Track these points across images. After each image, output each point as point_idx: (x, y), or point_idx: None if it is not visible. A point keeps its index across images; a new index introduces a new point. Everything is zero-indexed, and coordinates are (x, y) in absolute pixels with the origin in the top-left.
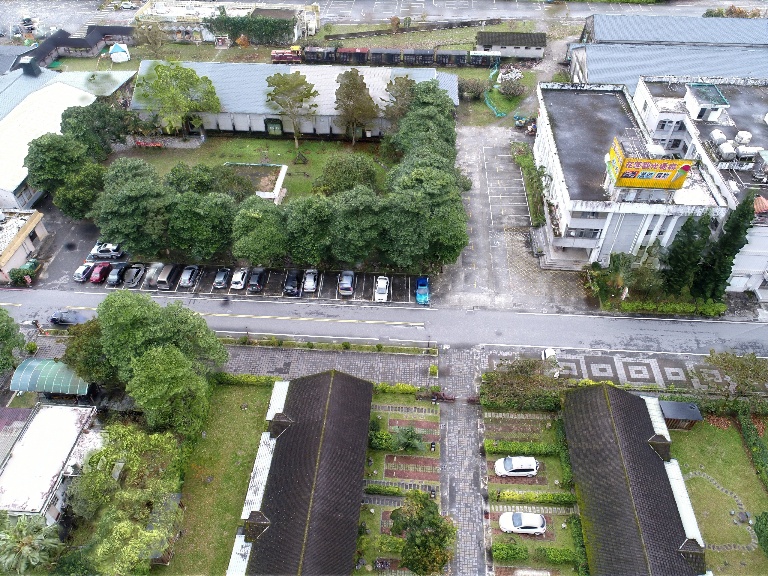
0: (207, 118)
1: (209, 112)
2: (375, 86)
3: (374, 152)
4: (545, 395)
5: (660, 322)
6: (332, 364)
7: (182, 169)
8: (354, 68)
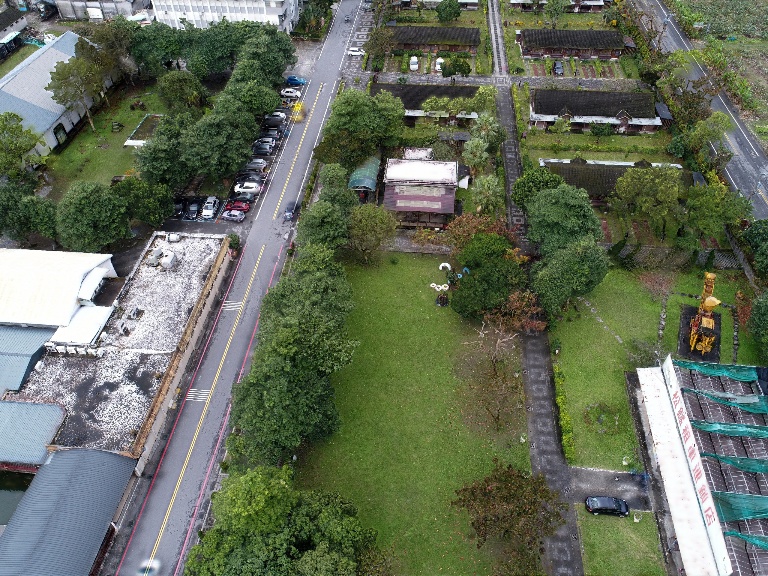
0: (22, 165)
1: (22, 156)
2: (65, 62)
3: (125, 98)
4: None
5: (333, 28)
6: None
7: (167, 124)
8: (79, 37)
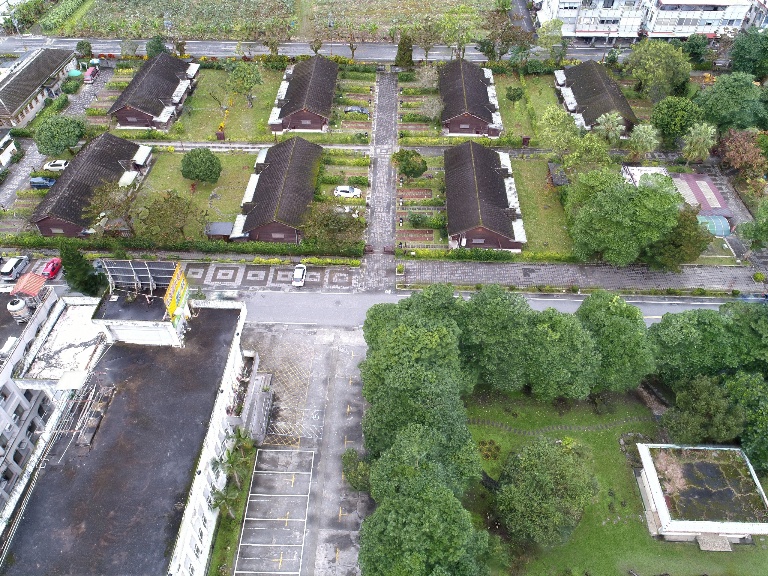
0: None
1: None
2: None
3: None
4: (314, 244)
5: None
6: (488, 276)
7: None
8: None
